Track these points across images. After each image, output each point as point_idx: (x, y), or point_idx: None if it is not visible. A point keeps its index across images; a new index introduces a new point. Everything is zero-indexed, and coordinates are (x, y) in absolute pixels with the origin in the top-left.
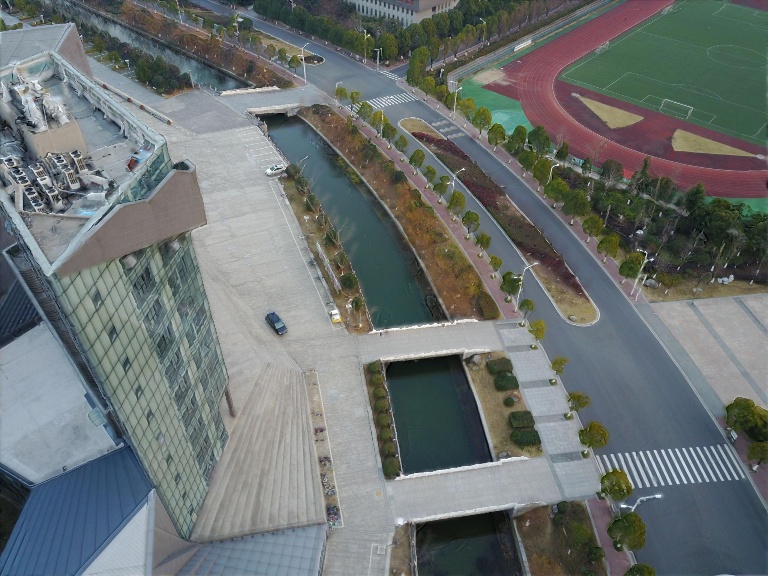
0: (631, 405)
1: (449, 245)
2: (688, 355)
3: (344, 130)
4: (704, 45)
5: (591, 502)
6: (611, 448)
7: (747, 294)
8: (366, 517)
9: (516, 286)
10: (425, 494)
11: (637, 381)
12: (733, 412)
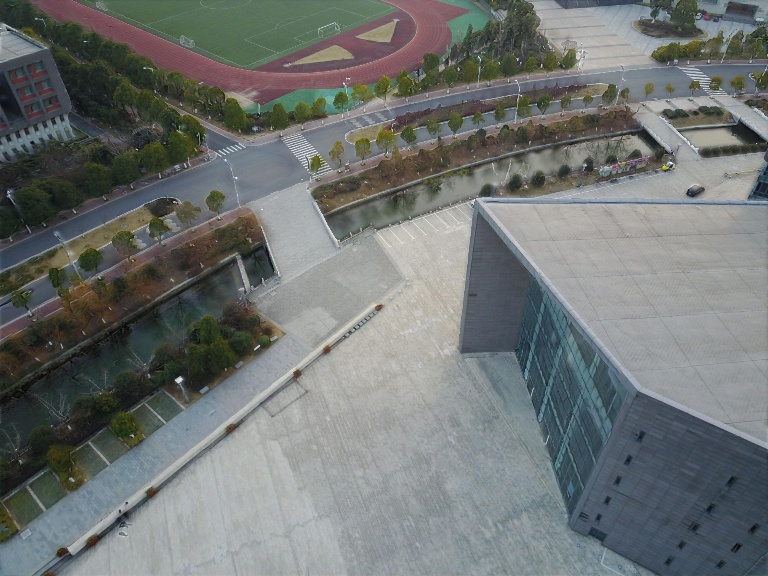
0: None
1: (558, 124)
2: None
3: (387, 169)
4: (197, 6)
5: None
6: (703, 92)
7: None
8: None
9: (616, 90)
10: None
11: (651, 80)
12: None
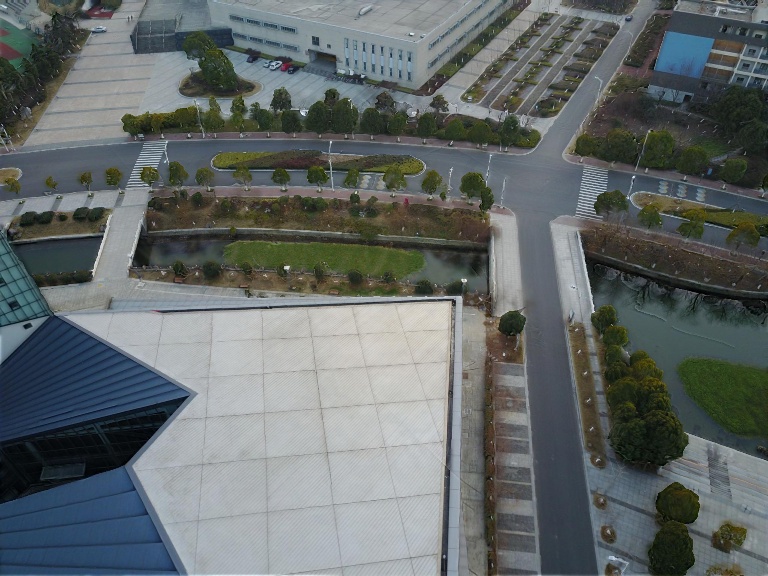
0: (99, 169)
1: None
2: (77, 141)
3: None
4: None
5: (153, 196)
6: (123, 182)
7: (45, 110)
8: (114, 291)
9: None
10: (112, 262)
11: (83, 163)
12: (129, 125)
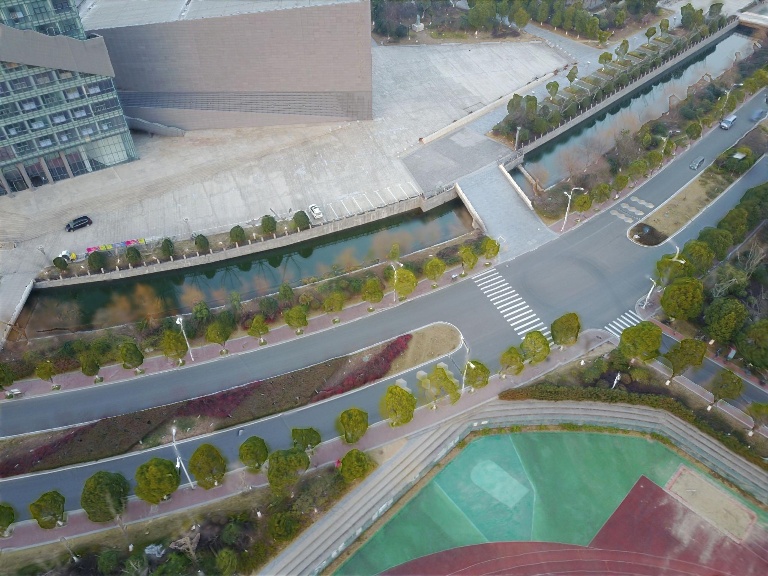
0: None
1: None
2: None
3: None
4: None
5: None
6: None
7: None
8: None
9: None
10: None
11: None
12: None
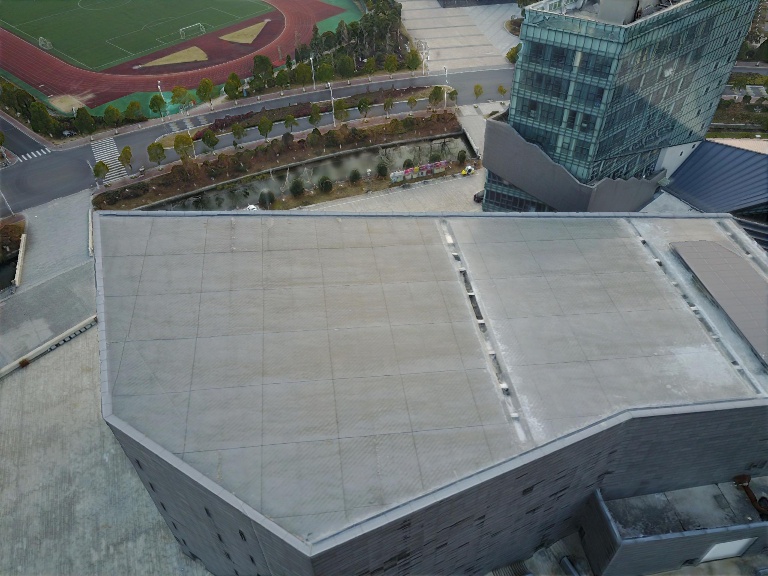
0: None
1: (378, 127)
2: (471, 67)
3: (177, 175)
4: (73, 7)
5: None
6: None
7: None
8: None
9: (442, 92)
10: None
11: None
12: None
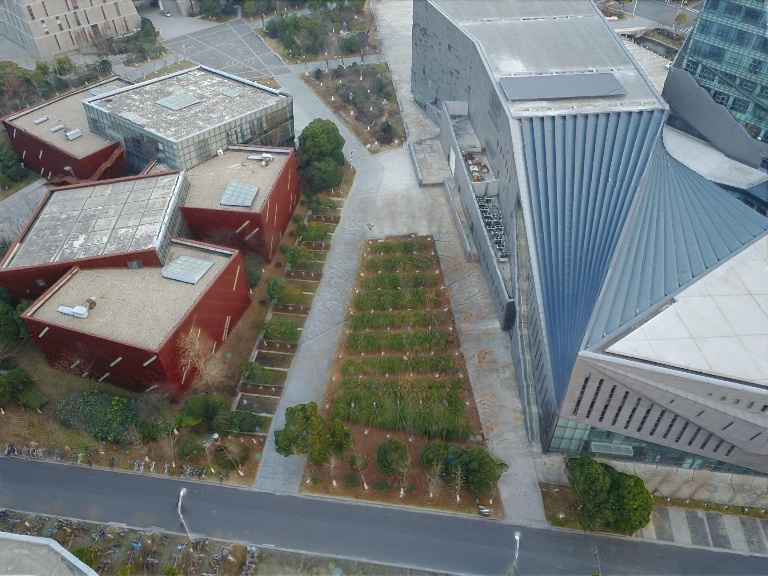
0: None
1: None
2: None
3: None
4: None
5: None
6: None
7: None
8: None
9: None
10: None
11: None
12: None
